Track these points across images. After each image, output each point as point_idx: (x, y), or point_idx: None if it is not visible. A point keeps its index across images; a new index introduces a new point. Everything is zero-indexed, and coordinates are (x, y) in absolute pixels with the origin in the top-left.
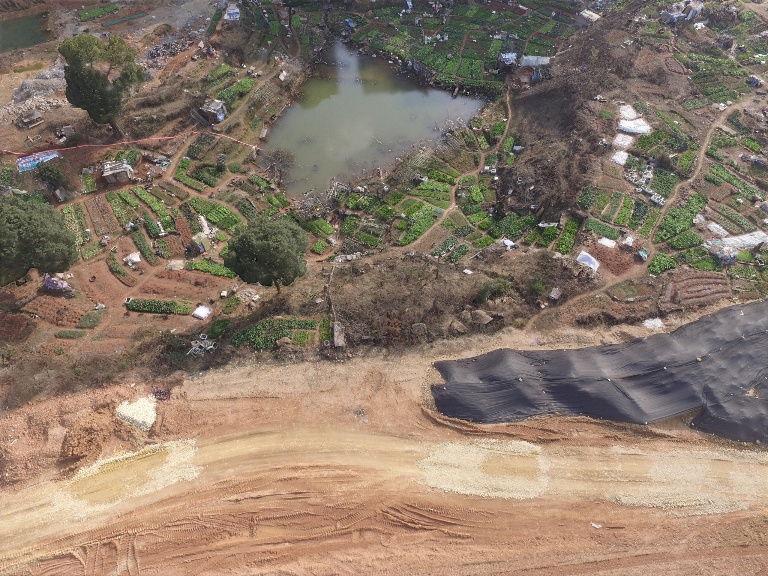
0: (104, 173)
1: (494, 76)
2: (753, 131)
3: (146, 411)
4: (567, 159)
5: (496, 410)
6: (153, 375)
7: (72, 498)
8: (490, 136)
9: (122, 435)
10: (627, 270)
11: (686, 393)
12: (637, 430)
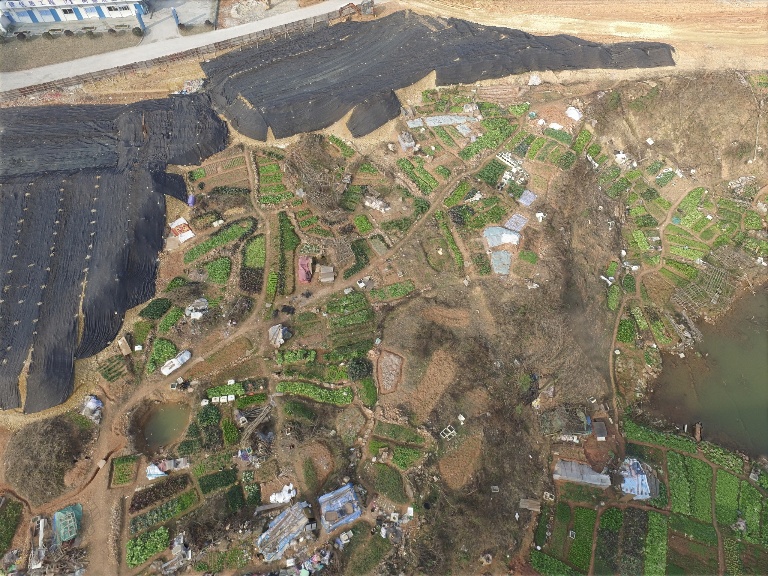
0: None
1: (645, 459)
2: None
3: None
4: None
5: None
6: None
7: None
8: None
9: None
10: (545, 108)
11: (538, 40)
12: None
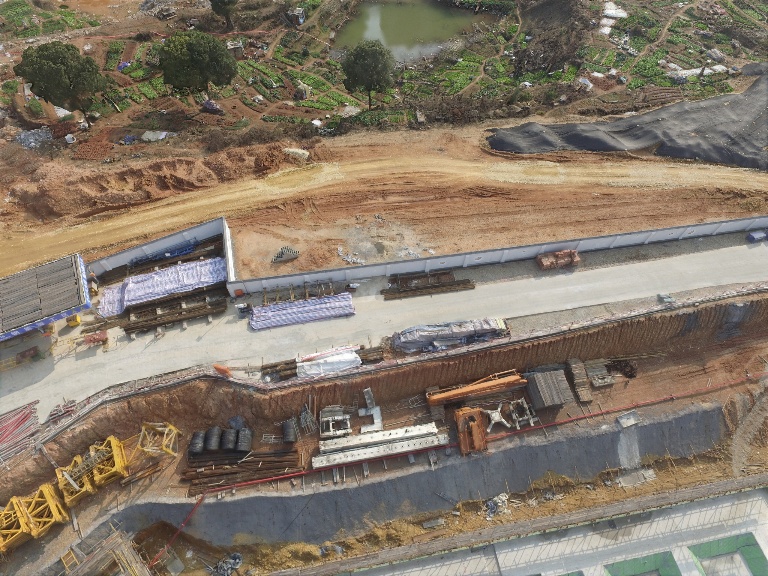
0: (228, 47)
1: None
2: (703, 19)
3: (302, 151)
4: (567, 35)
5: (529, 148)
6: (299, 139)
7: (268, 186)
8: (506, 34)
9: (290, 160)
10: (612, 88)
11: (651, 136)
12: (620, 155)
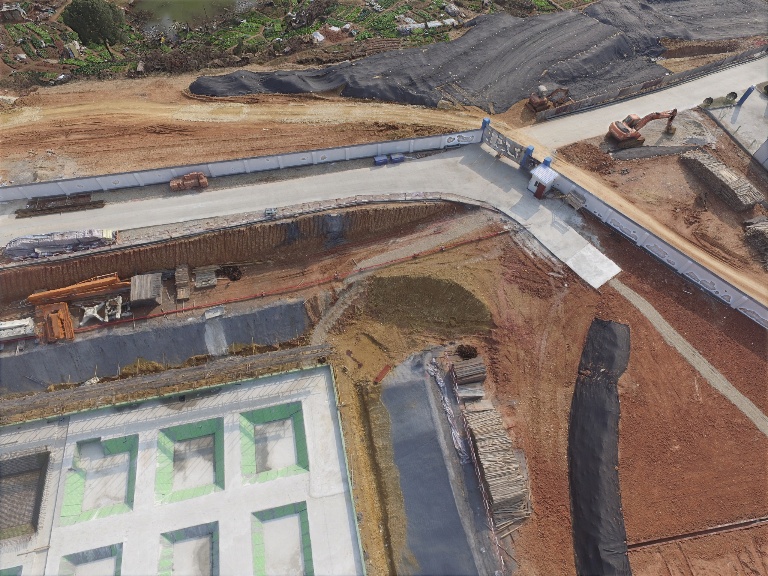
0: (2, 10)
1: None
2: None
3: None
4: None
5: (226, 92)
6: (20, 89)
7: None
8: None
9: None
10: (341, 40)
11: (340, 79)
12: (307, 96)
